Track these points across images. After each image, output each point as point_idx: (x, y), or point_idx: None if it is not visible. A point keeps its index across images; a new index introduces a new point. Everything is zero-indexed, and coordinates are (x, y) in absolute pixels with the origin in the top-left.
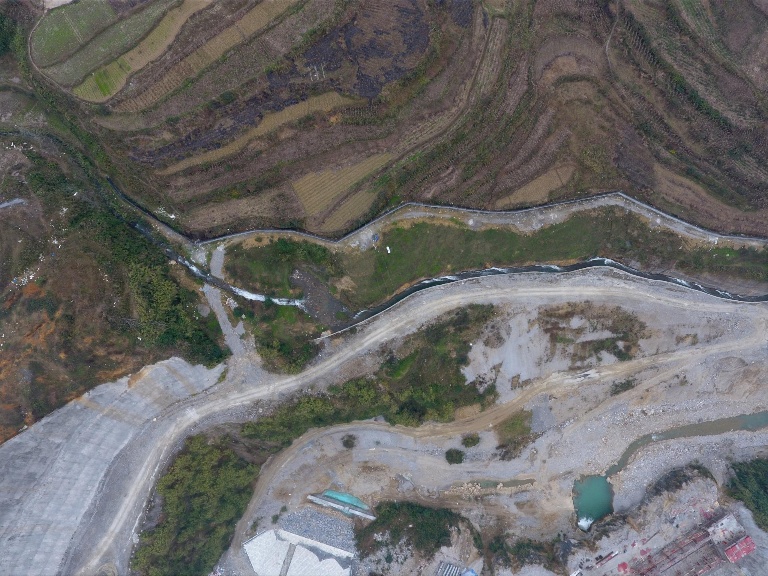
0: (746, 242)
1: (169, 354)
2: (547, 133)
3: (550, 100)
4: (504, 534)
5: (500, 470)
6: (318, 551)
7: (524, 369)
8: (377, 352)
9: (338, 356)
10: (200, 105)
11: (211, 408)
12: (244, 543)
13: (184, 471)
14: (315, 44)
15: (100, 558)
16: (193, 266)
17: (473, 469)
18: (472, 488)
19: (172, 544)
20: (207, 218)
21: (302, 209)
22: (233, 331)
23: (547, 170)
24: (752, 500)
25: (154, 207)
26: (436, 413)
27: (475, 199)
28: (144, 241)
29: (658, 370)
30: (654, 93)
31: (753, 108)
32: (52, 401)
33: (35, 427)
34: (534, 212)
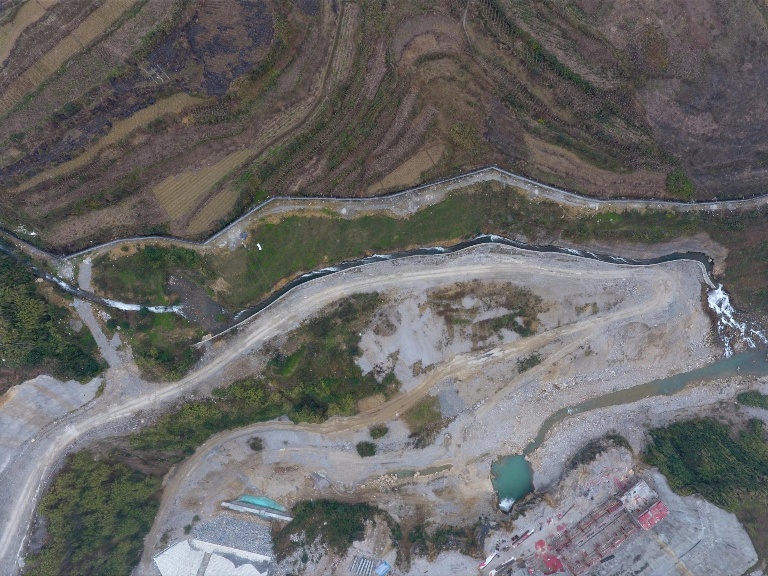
0: (628, 205)
1: (36, 373)
2: (412, 114)
3: (413, 80)
4: (424, 523)
5: (415, 459)
6: (234, 558)
7: (424, 354)
8: (261, 351)
9: (220, 359)
10: (43, 118)
11: (91, 423)
12: (154, 557)
13: (67, 489)
14: (157, 46)
15: None
16: (62, 282)
17: (387, 460)
18: (389, 479)
19: (66, 564)
20: (69, 232)
21: (164, 214)
22: (109, 343)
23: (417, 151)
24: (667, 465)
25: (14, 226)
26: (337, 407)
27: (344, 187)
28: (7, 261)
29: (562, 343)
30: (516, 63)
31: (614, 69)
32: None
33: None
34: (409, 195)
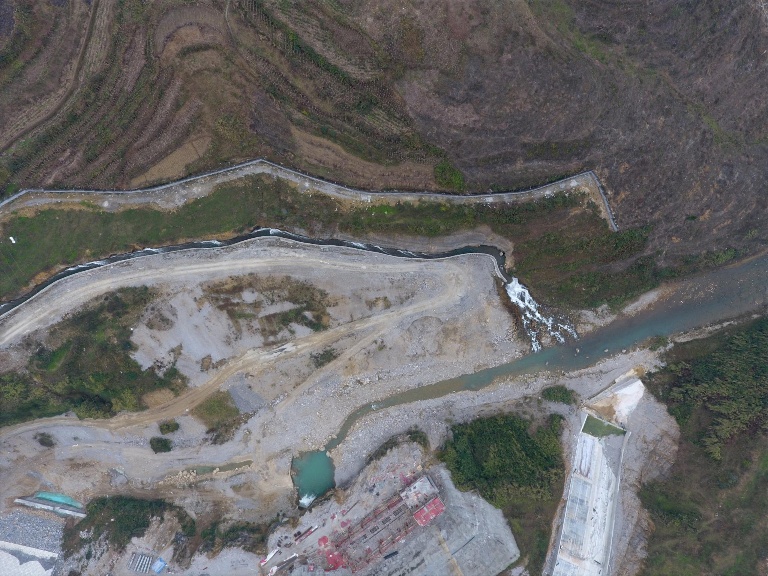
0: (400, 197)
1: None
2: (175, 106)
3: (177, 72)
4: (221, 519)
5: (213, 454)
6: (21, 554)
7: (213, 349)
8: (21, 345)
9: None
10: None
11: None
12: None
13: None
14: None
15: None
16: None
17: (184, 456)
18: (187, 476)
19: None
20: None
21: None
22: None
23: (182, 144)
24: (456, 460)
25: None
26: (120, 402)
27: (103, 180)
28: None
29: (356, 337)
30: (277, 55)
31: (372, 60)
32: None
33: None
34: (176, 188)
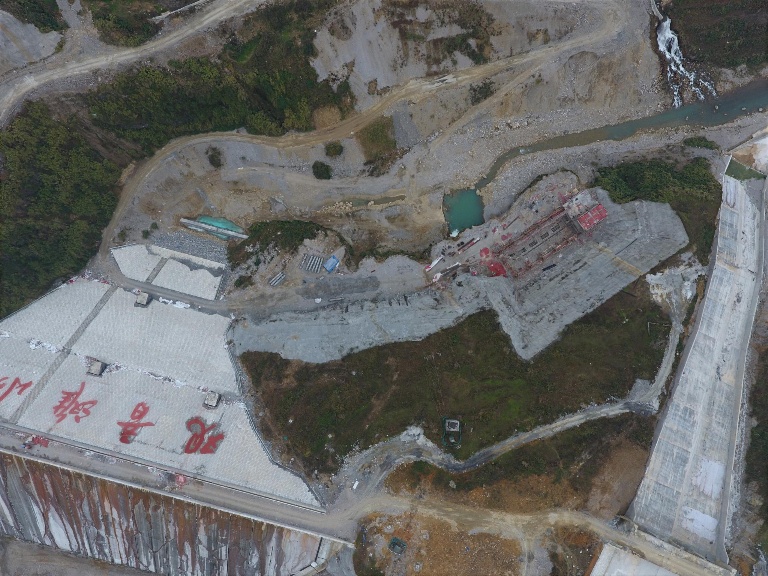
0: None
1: None
2: None
3: None
4: (376, 247)
5: (369, 186)
6: (190, 263)
7: (380, 73)
8: (217, 31)
9: (177, 33)
10: None
11: (50, 76)
12: (111, 248)
13: (24, 133)
14: None
15: None
16: None
17: (342, 185)
18: (343, 206)
19: (22, 214)
20: None
21: None
22: (70, 7)
23: None
24: (610, 185)
25: None
26: (293, 115)
27: None
28: None
29: (514, 71)
30: None
31: None
32: None
33: None
34: None
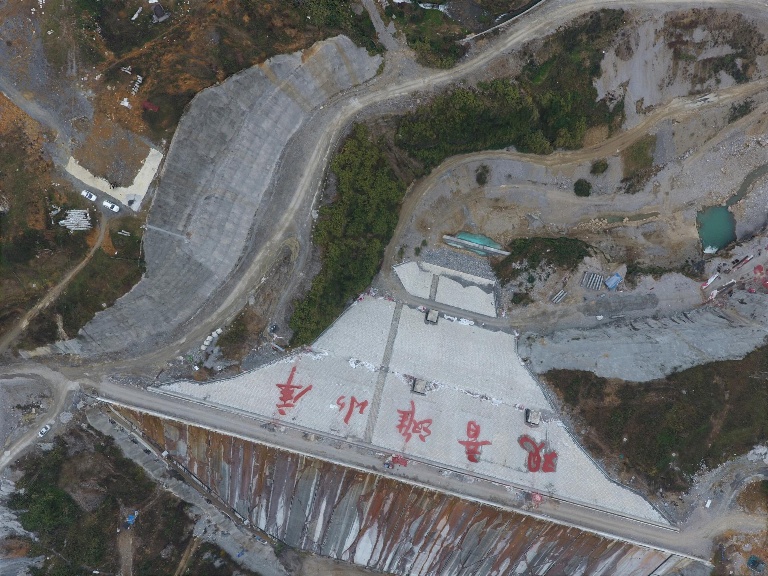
0: None
1: (337, 32)
2: None
3: None
4: (634, 263)
5: (626, 203)
6: (460, 280)
7: (647, 92)
8: (519, 53)
9: (484, 55)
10: None
11: (372, 98)
12: (394, 266)
13: (353, 155)
14: None
15: (283, 233)
16: None
17: (600, 202)
18: (599, 223)
19: (342, 234)
20: None
21: None
22: (385, 30)
23: None
24: None
25: None
26: (568, 134)
27: None
28: None
29: None
30: None
31: None
32: (240, 61)
33: (226, 84)
34: None
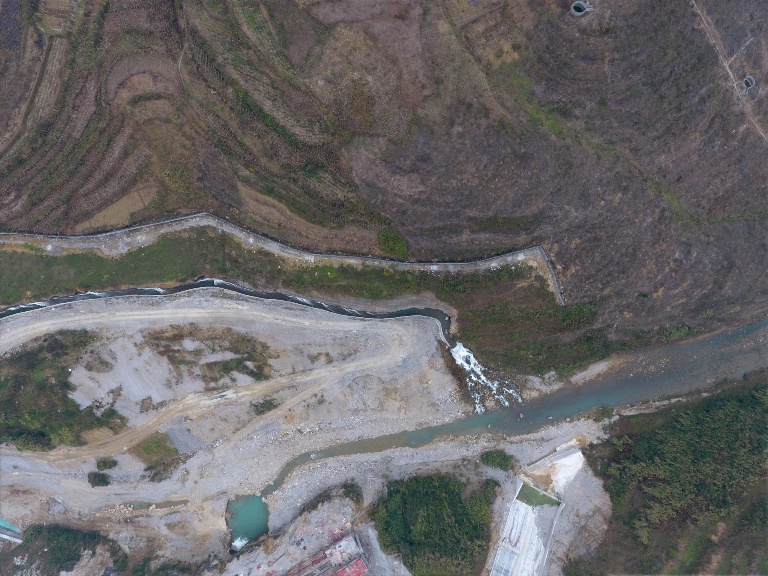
0: (344, 260)
1: None
2: (123, 154)
3: (127, 120)
4: (154, 556)
5: (150, 492)
6: None
7: (153, 391)
8: None
9: None
10: None
11: None
12: None
13: None
14: None
15: None
16: None
17: (121, 491)
18: (124, 510)
19: None
20: None
21: None
22: None
23: (128, 192)
24: (385, 520)
25: None
26: (57, 438)
27: (47, 224)
28: None
29: (296, 389)
30: (228, 110)
31: (321, 123)
32: None
33: None
34: (120, 235)
